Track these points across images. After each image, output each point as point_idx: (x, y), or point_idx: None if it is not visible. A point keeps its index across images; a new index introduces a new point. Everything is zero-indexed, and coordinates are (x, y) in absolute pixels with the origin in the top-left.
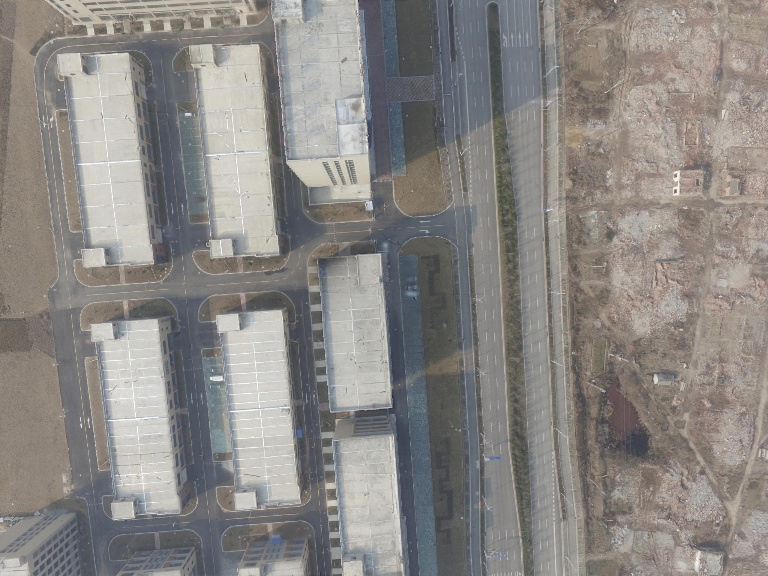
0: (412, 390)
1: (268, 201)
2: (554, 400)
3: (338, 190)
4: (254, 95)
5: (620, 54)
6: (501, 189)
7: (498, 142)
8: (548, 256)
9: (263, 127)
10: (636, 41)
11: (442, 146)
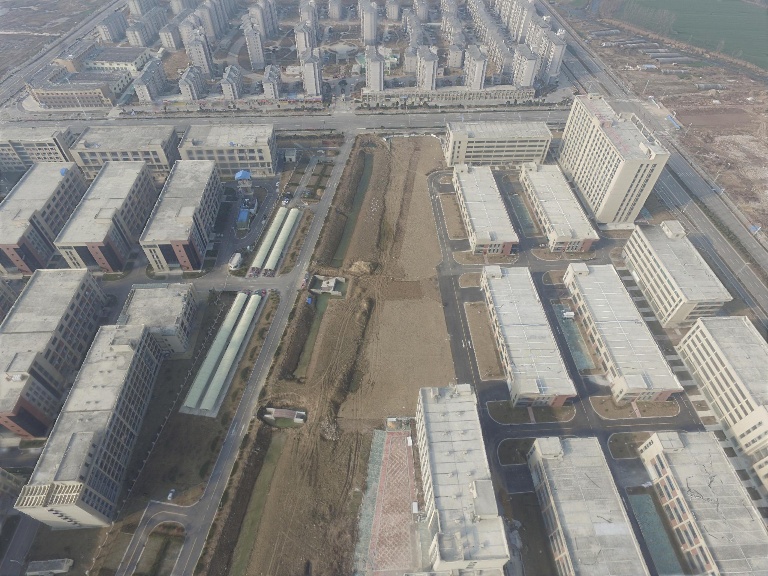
0: None
1: (582, 218)
2: None
3: (613, 227)
4: (559, 181)
5: (747, 180)
6: (718, 225)
7: (702, 207)
8: None
9: (568, 191)
10: (752, 176)
11: (669, 209)
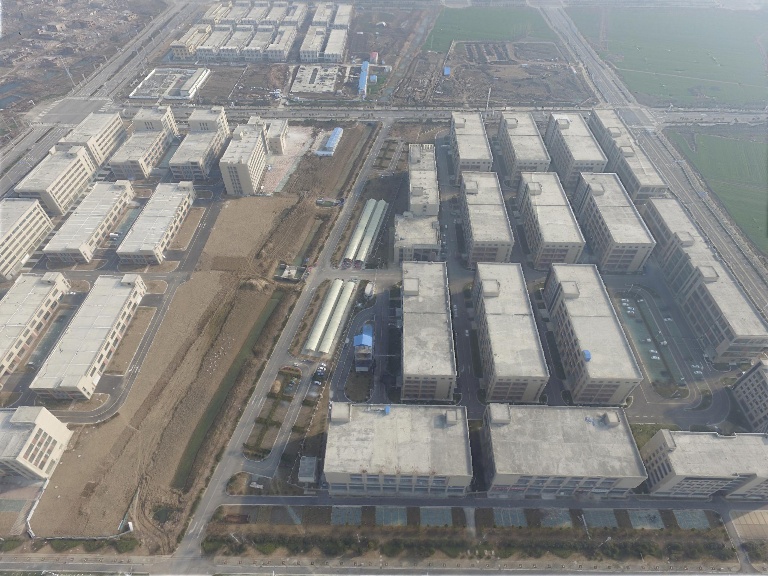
0: None
1: (7, 300)
2: None
3: None
4: None
5: None
6: None
7: None
8: None
9: None
10: None
11: None
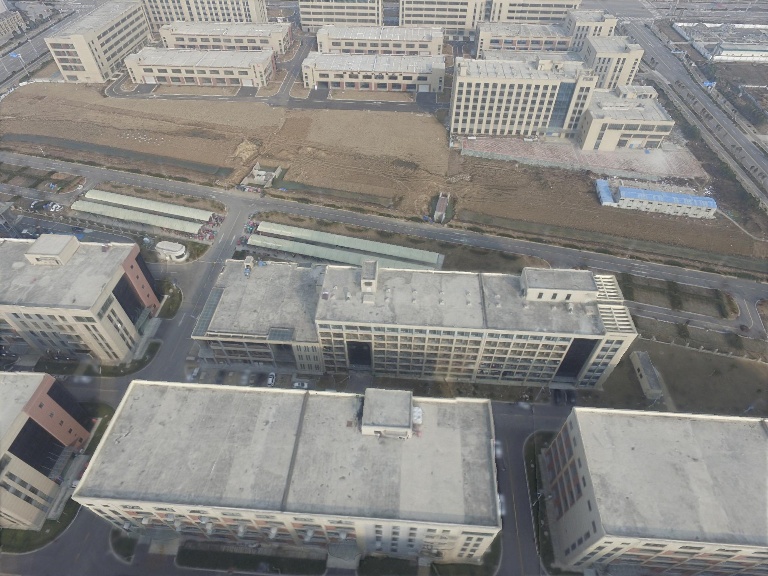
0: None
1: (260, 25)
2: None
3: None
4: None
5: None
6: None
7: None
8: None
9: None
10: None
11: None
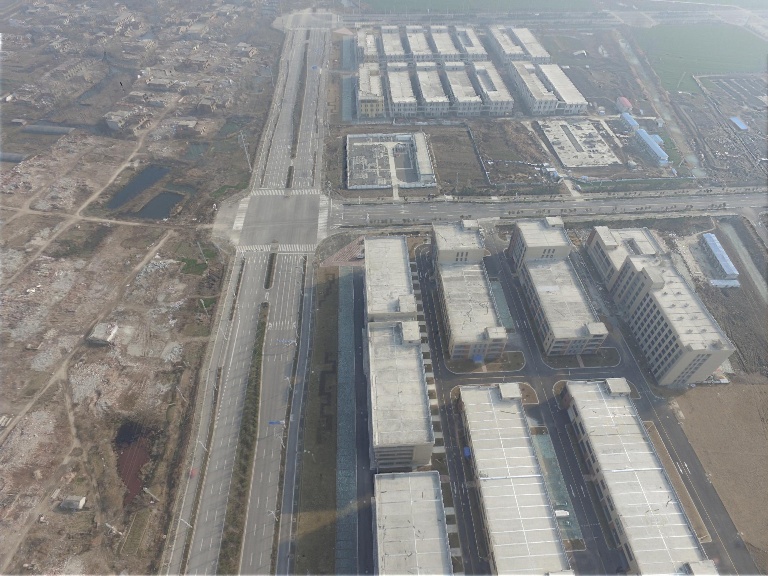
0: (351, 496)
1: None
2: (201, 481)
3: None
4: None
5: None
6: None
7: None
8: None
9: None
10: None
11: None
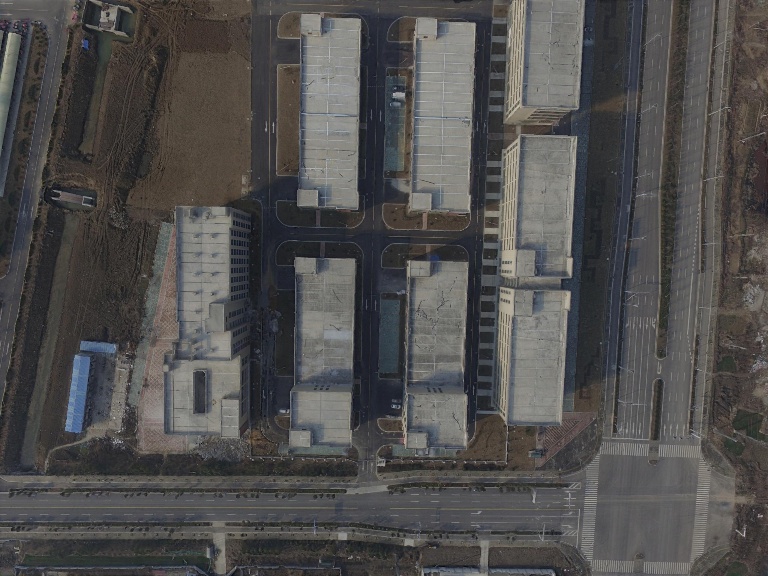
0: (576, 129)
1: None
2: (706, 153)
3: None
4: None
5: None
6: None
7: None
8: (717, 13)
9: None
10: None
11: None
